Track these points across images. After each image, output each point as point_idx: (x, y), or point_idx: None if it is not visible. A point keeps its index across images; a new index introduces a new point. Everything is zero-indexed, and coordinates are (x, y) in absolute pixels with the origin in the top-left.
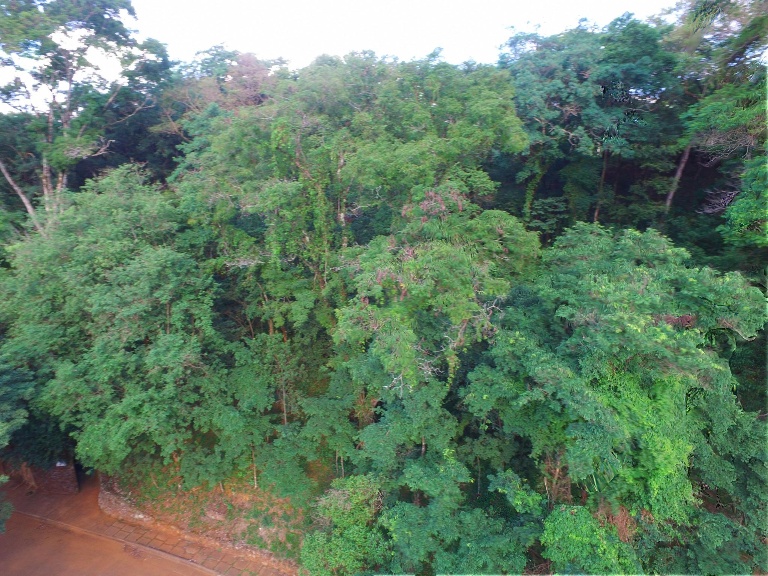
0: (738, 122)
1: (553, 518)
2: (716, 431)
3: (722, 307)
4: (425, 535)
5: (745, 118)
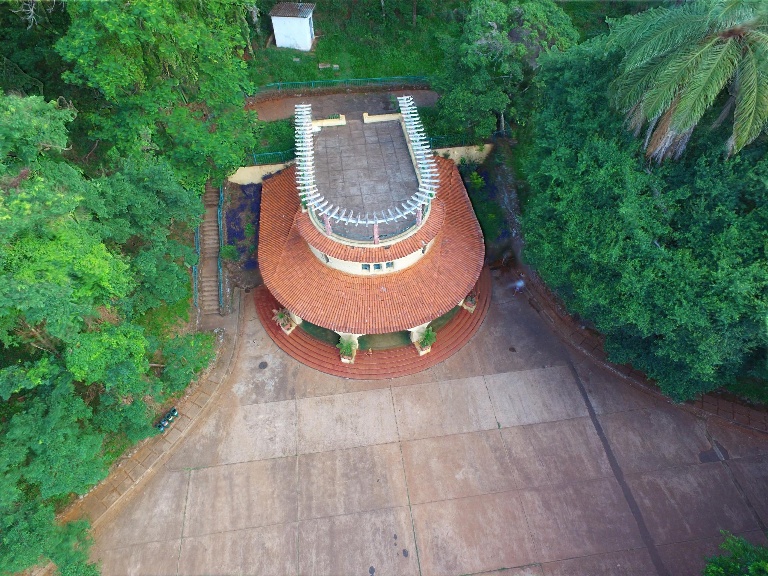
0: None
1: (71, 363)
2: (101, 215)
3: None
4: (1, 480)
5: None
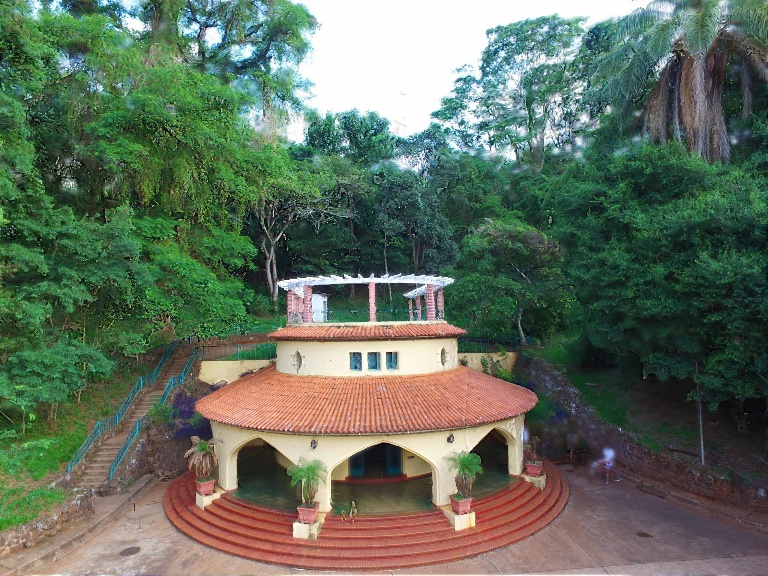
0: None
1: None
2: (19, 168)
3: (6, 16)
4: None
5: None
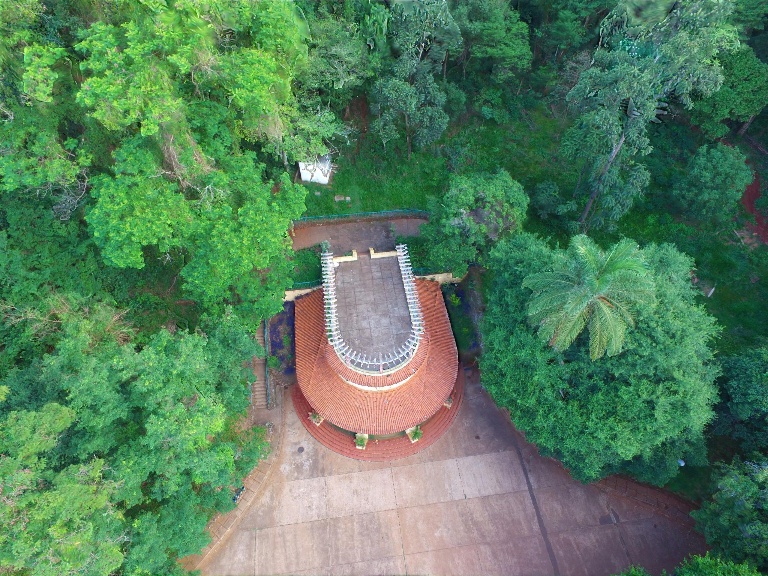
0: (48, 181)
1: (195, 475)
2: None
3: None
4: (158, 551)
5: (53, 180)
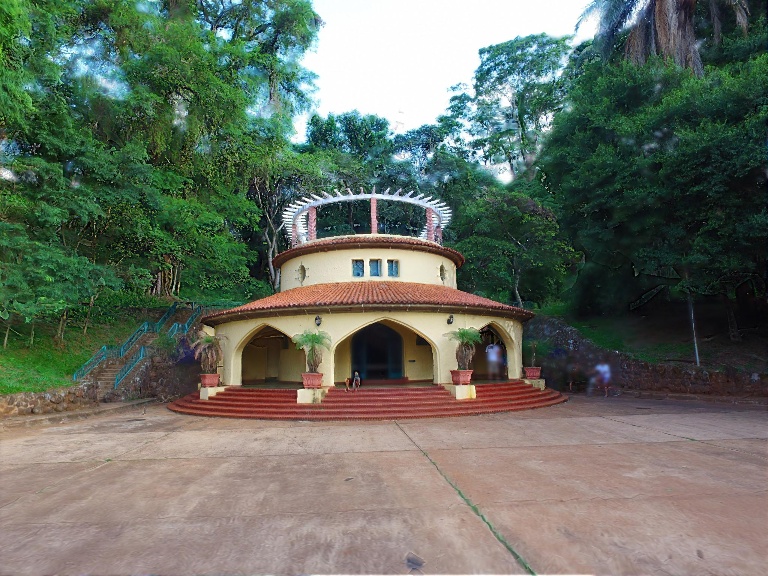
0: None
1: None
2: (48, 74)
3: None
4: None
5: None
